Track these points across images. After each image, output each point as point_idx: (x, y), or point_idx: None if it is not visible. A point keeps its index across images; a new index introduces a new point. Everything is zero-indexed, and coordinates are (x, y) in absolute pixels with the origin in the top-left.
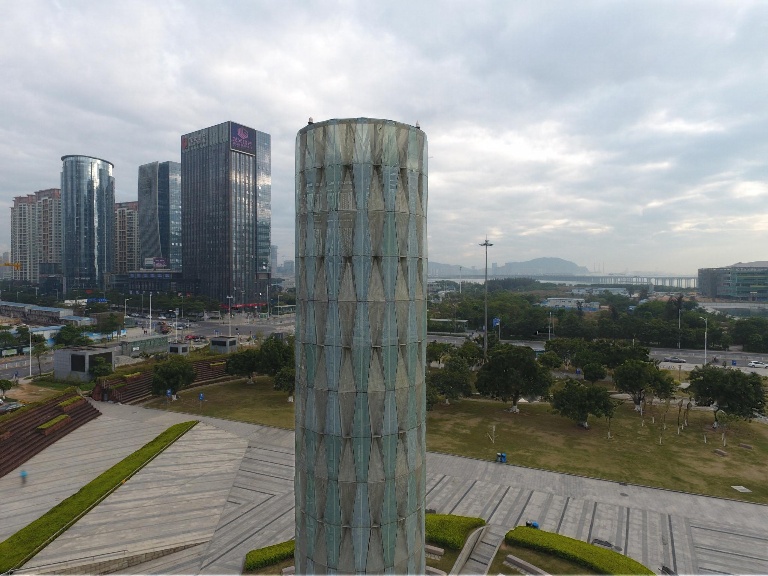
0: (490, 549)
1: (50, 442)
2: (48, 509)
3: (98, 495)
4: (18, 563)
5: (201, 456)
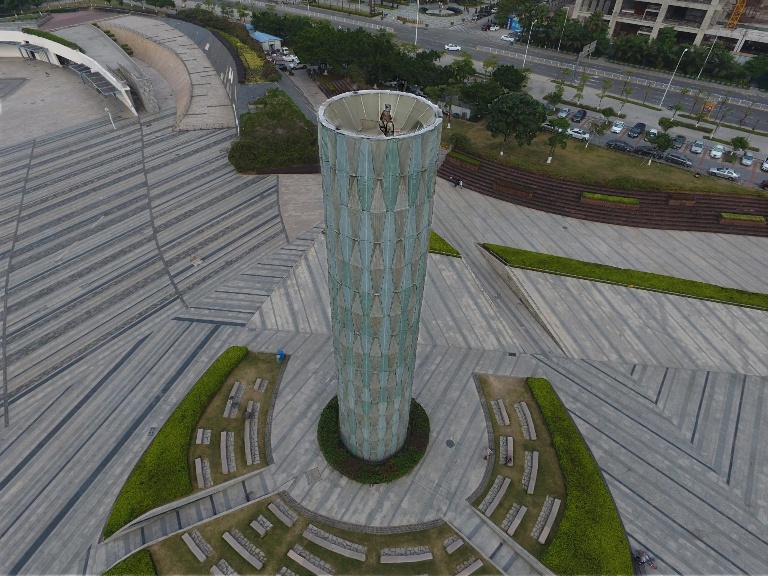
0: None
1: (713, 230)
2: (600, 263)
3: (600, 277)
4: (515, 265)
5: (718, 333)
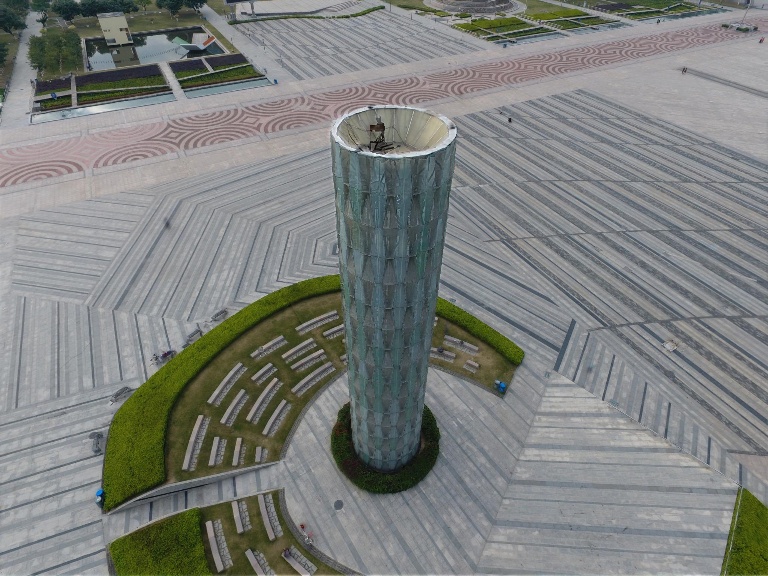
0: (159, 512)
1: None
2: None
3: None
4: None
5: None
